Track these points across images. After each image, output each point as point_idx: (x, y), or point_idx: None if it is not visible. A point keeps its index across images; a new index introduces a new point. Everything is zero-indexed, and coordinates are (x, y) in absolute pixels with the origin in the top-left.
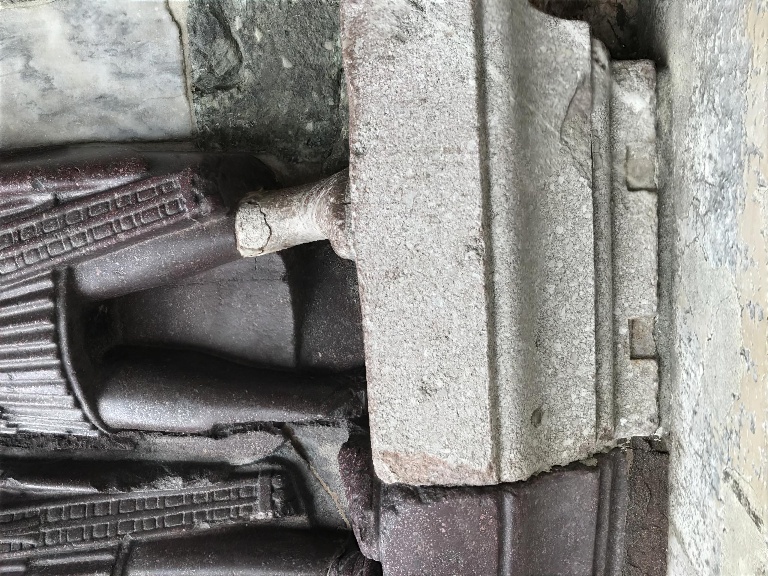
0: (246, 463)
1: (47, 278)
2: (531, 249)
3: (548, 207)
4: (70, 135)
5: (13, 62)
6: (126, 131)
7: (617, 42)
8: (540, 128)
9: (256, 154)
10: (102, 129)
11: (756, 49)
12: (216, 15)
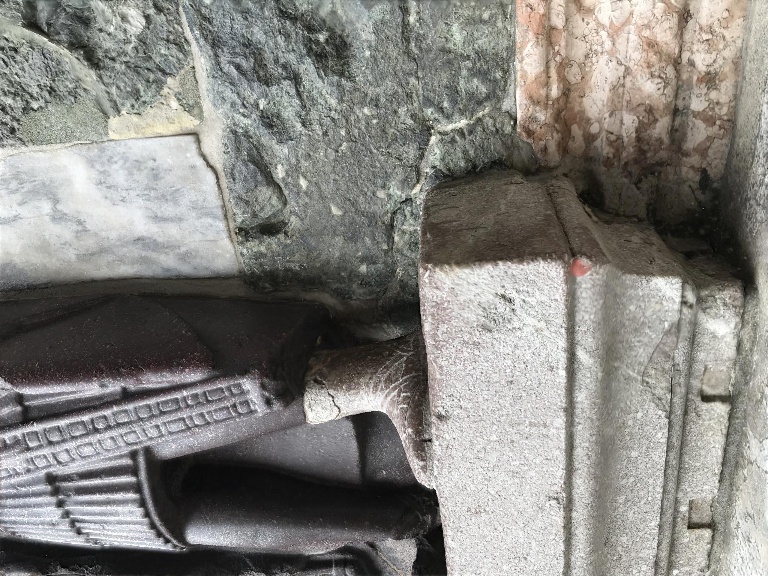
0: (320, 553)
1: (126, 457)
2: (607, 479)
3: (625, 439)
4: (111, 272)
5: (38, 205)
6: (170, 270)
7: (697, 205)
8: (623, 377)
9: (308, 291)
10: (144, 268)
11: None
12: (256, 163)
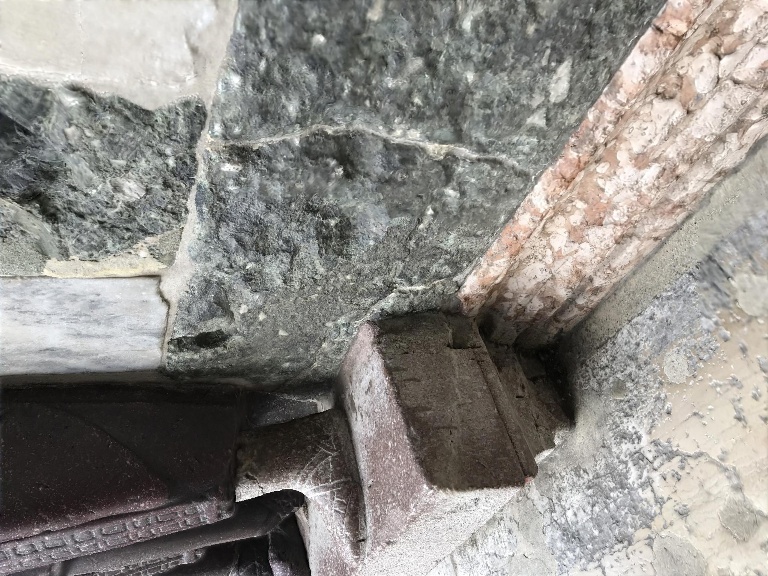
0: None
1: None
2: None
3: None
4: None
5: None
6: (76, 369)
7: None
8: None
9: (225, 377)
10: (43, 368)
11: (633, 550)
12: (220, 304)
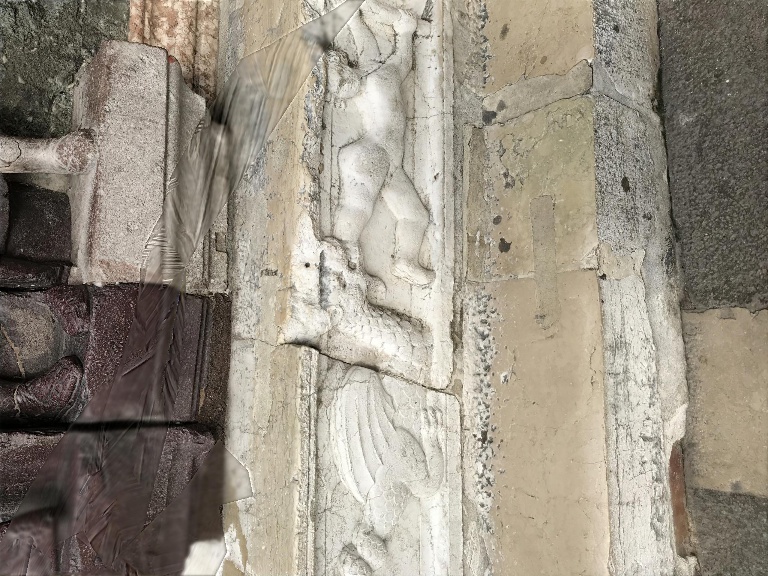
0: None
1: None
2: None
3: None
4: None
5: None
6: None
7: None
8: (185, 131)
9: None
10: None
11: None
12: None
